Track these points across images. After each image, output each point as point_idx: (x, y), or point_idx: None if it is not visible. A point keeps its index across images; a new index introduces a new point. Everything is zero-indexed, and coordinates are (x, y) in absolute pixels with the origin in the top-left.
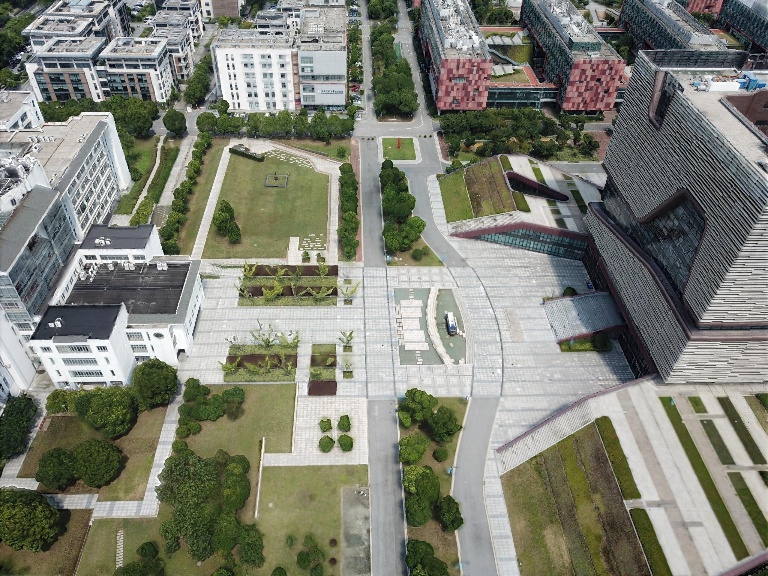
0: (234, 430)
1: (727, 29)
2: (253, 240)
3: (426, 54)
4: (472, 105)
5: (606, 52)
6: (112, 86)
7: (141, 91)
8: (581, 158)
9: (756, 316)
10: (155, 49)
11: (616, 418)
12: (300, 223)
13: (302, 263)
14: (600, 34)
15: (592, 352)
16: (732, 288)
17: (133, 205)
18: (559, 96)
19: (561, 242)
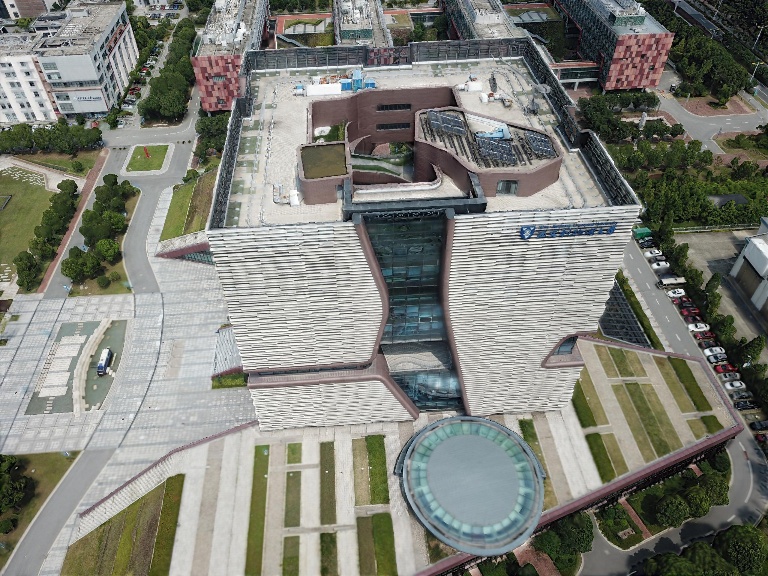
0: None
1: (552, 2)
2: None
3: None
4: None
5: (379, 39)
6: None
7: None
8: None
9: (304, 360)
10: None
11: (193, 475)
12: None
13: None
14: (416, 15)
15: (245, 387)
16: (250, 334)
17: None
18: None
19: None
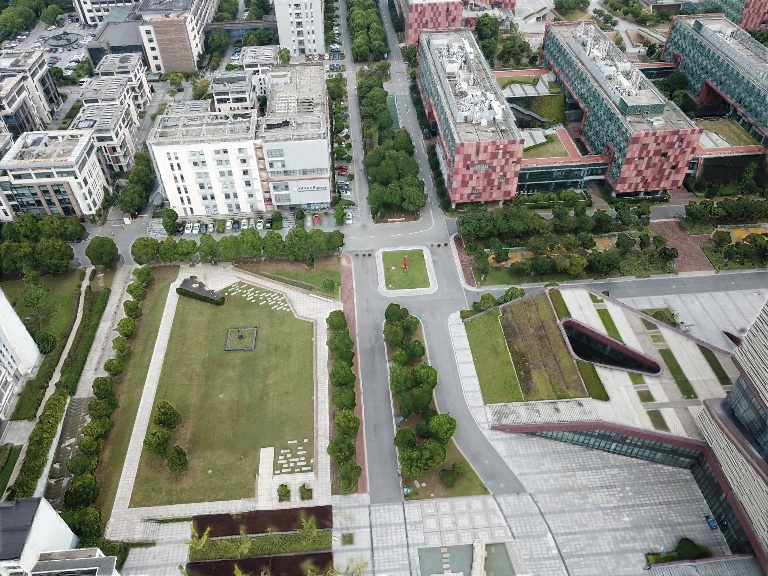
0: None
1: None
2: (207, 460)
3: (429, 115)
4: (497, 195)
5: (671, 115)
6: (21, 201)
7: (60, 204)
8: (652, 270)
9: None
10: (73, 150)
11: None
12: (275, 419)
13: (279, 503)
14: (643, 71)
15: None
16: None
17: (38, 401)
18: (609, 172)
19: (659, 447)
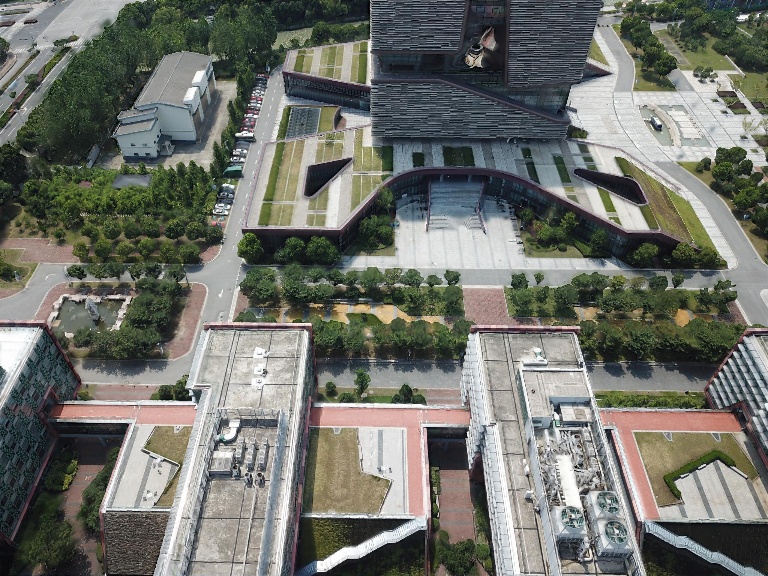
0: (764, 81)
1: None
2: None
3: None
4: None
5: (501, 377)
6: None
7: None
8: None
9: None
10: None
11: None
12: None
13: None
14: None
15: None
16: None
17: None
18: None
19: None
